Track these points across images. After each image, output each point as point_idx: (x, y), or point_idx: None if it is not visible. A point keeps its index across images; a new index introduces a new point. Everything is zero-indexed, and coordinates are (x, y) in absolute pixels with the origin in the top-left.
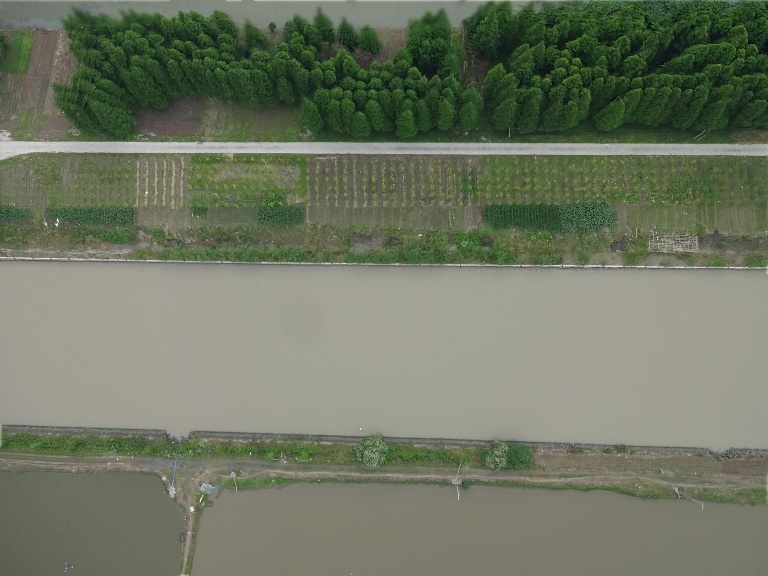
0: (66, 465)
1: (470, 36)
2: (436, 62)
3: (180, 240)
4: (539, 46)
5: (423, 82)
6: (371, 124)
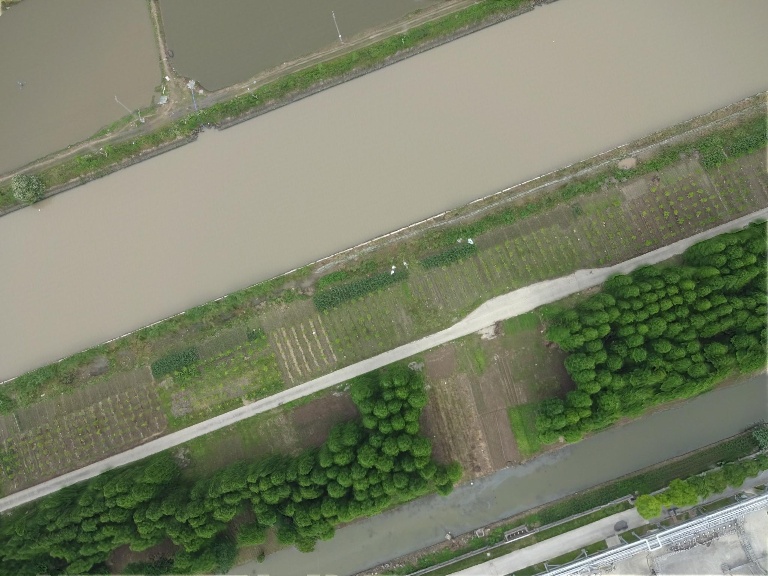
0: (293, 65)
1: None
2: None
3: None
4: None
5: (44, 544)
6: None
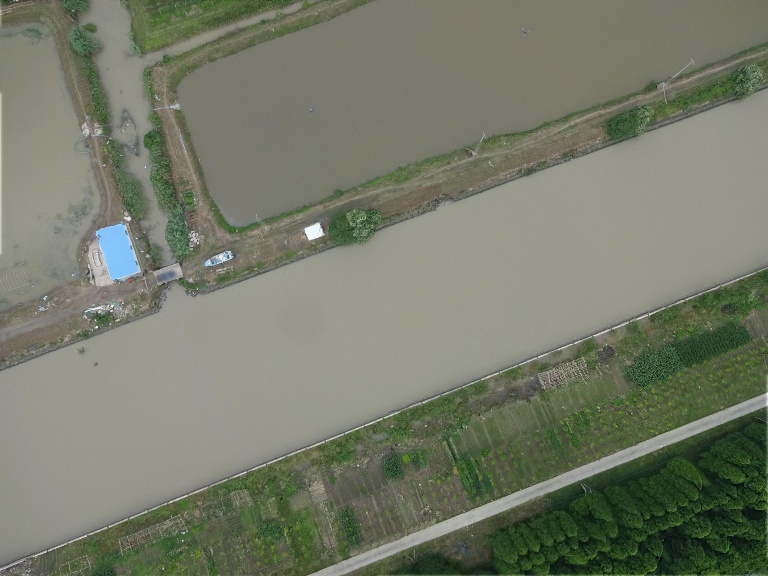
0: None
1: None
2: None
3: None
4: None
5: None
6: None
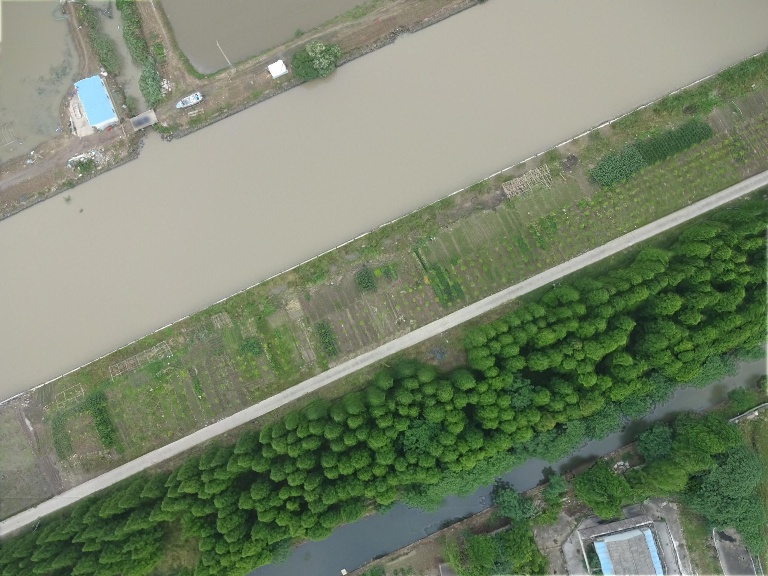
0: None
1: None
2: None
3: None
4: None
5: None
6: None
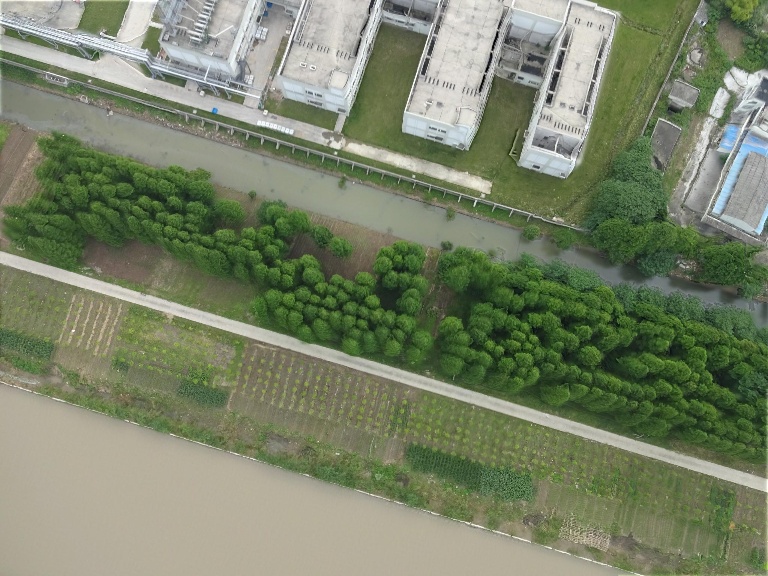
0: None
1: (444, 262)
2: (403, 281)
3: (94, 387)
4: (502, 310)
5: (377, 315)
6: (316, 336)
